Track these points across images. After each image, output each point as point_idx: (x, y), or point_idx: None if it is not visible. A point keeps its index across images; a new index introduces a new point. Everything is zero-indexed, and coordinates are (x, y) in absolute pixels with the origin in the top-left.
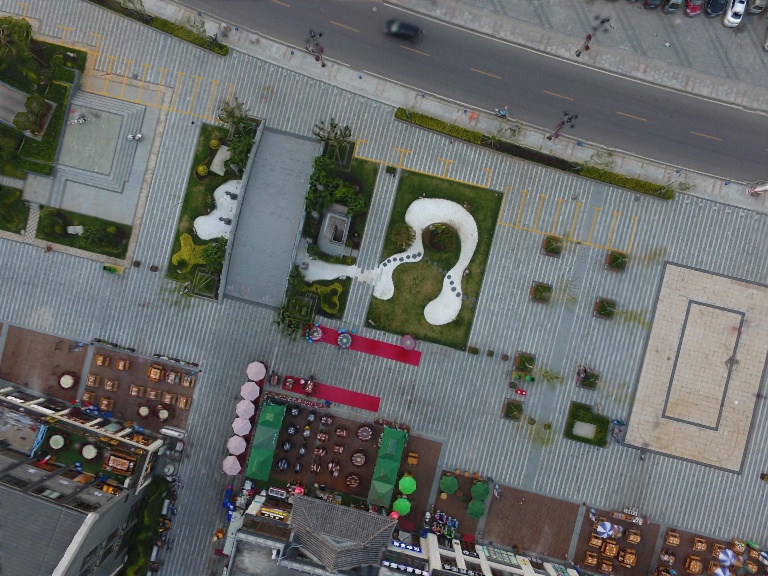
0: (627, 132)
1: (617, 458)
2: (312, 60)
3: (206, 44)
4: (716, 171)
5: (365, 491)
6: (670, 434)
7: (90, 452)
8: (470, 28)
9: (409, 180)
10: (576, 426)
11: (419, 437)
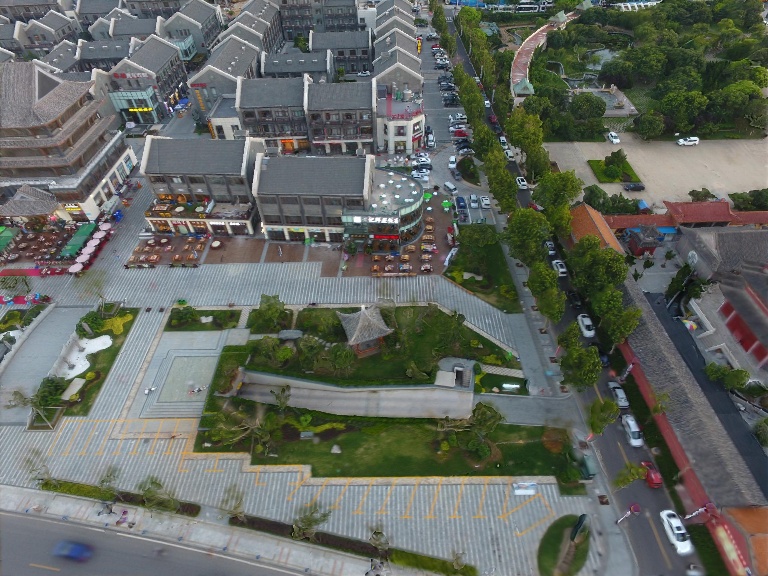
0: None
1: None
2: None
3: (61, 483)
4: None
5: None
6: None
7: (179, 209)
8: None
9: None
10: None
11: None
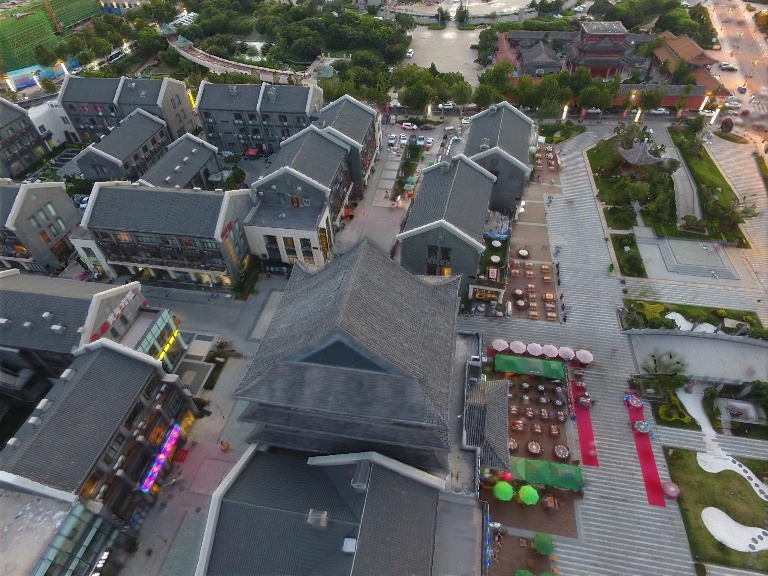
0: None
1: None
2: None
3: None
4: None
5: None
6: None
7: (496, 259)
8: None
9: None
10: None
11: (575, 511)
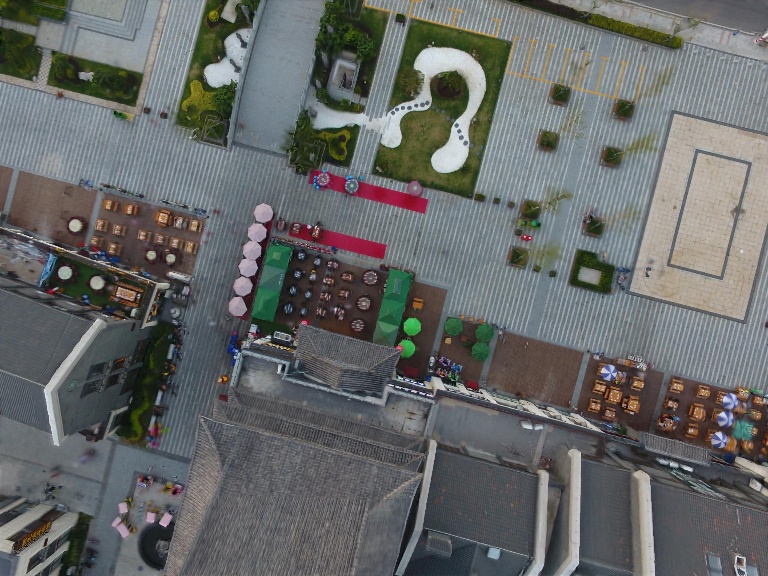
0: None
1: (622, 306)
2: None
3: None
4: (724, 22)
5: (370, 337)
6: (675, 282)
7: (98, 283)
8: None
9: (418, 28)
10: (581, 272)
11: (424, 284)
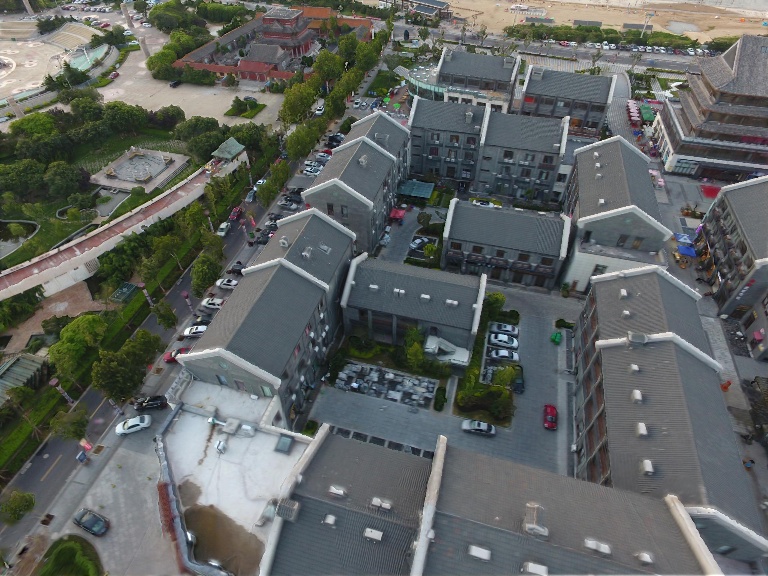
0: None
1: None
2: None
3: (570, 58)
4: None
5: None
6: None
7: None
8: (661, 59)
9: (661, 78)
10: None
11: None
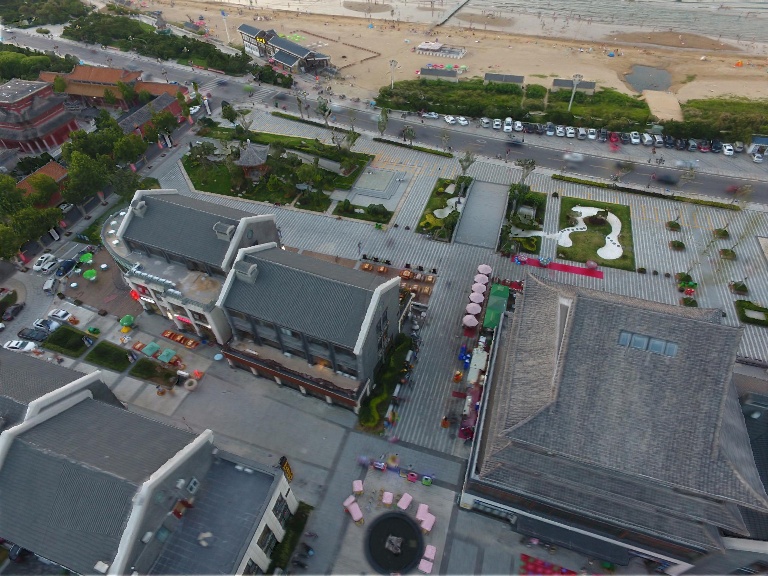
0: (694, 187)
1: None
2: (499, 161)
3: (442, 153)
4: (760, 202)
5: None
6: None
7: None
8: (584, 153)
9: (568, 199)
10: (746, 312)
11: None
